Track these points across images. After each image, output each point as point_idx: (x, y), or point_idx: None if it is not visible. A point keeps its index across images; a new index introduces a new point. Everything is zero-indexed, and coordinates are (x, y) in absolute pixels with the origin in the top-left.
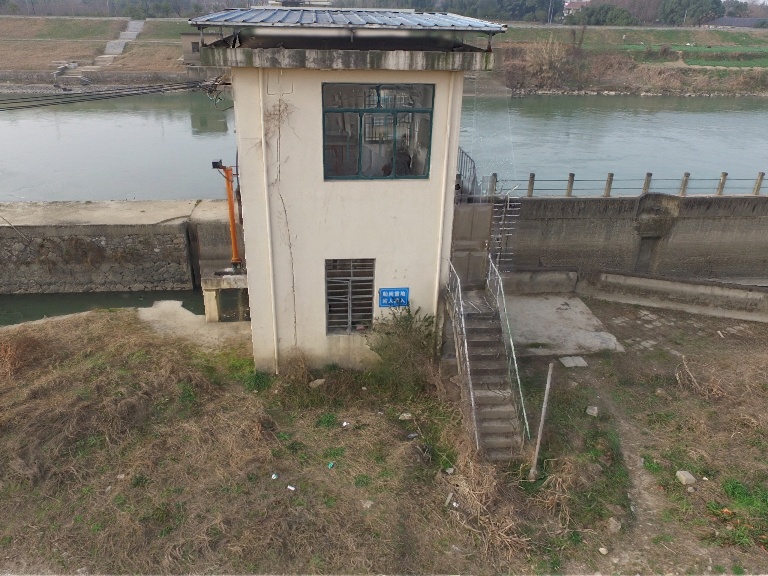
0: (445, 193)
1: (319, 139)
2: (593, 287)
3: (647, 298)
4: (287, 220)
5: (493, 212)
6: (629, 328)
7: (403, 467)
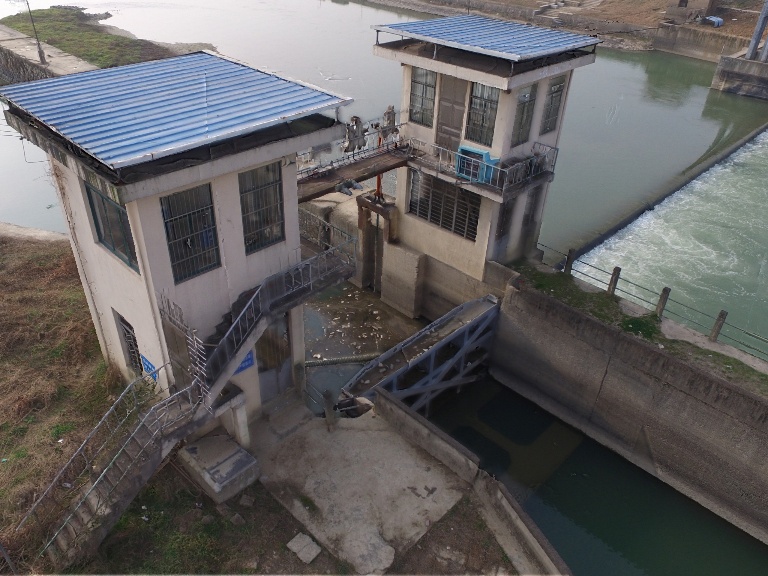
0: (151, 301)
1: (84, 207)
2: (488, 496)
3: (530, 561)
4: (86, 261)
5: (592, 335)
6: (437, 571)
7: (8, 499)
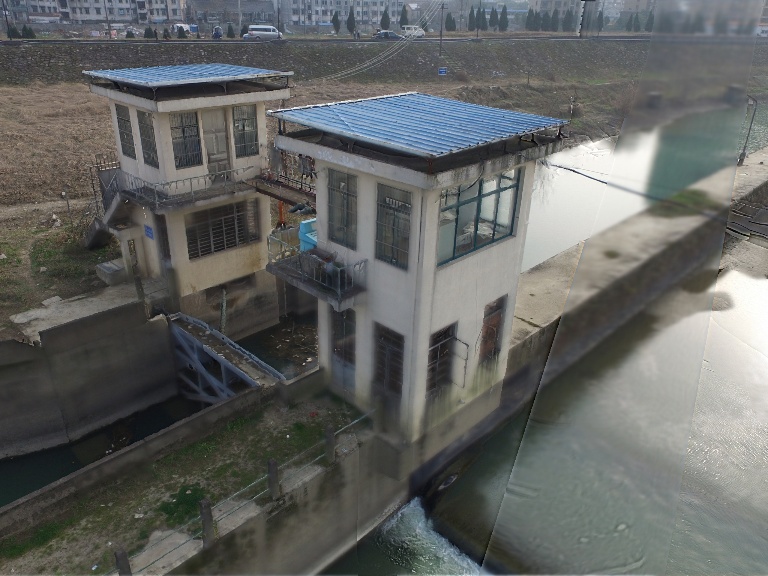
0: None
1: None
2: None
3: None
4: None
5: None
6: None
7: None
